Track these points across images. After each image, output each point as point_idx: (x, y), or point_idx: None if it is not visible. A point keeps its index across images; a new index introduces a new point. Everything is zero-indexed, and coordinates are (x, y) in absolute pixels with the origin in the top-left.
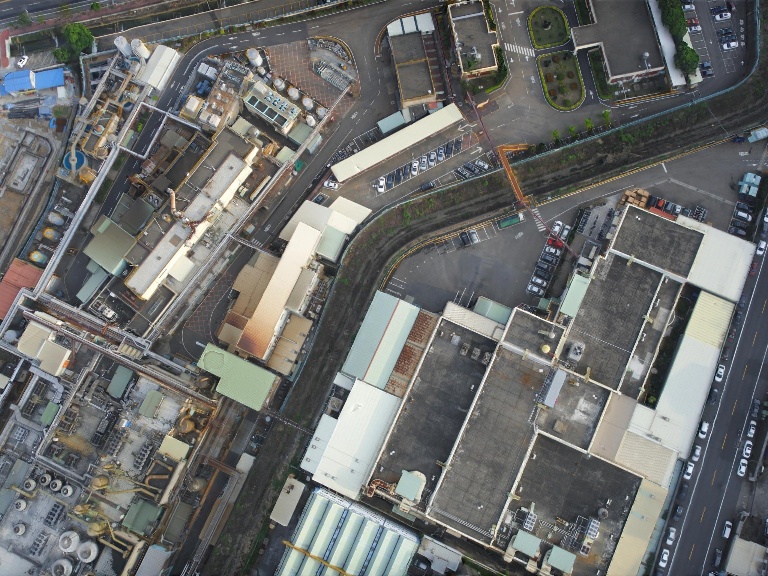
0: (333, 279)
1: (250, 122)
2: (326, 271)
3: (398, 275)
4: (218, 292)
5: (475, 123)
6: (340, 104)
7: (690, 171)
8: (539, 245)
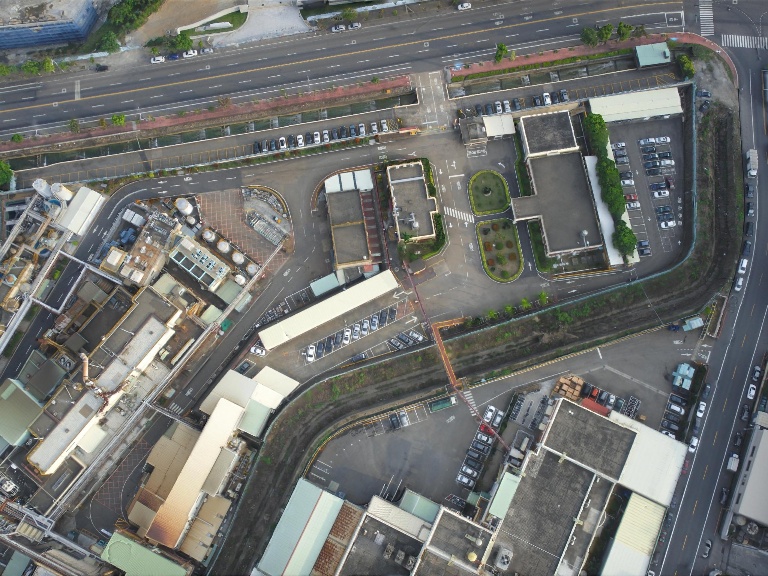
0: (256, 453)
1: (176, 274)
2: (249, 444)
3: (323, 458)
4: (132, 461)
5: (411, 290)
6: (272, 260)
7: (625, 358)
8: (471, 431)
